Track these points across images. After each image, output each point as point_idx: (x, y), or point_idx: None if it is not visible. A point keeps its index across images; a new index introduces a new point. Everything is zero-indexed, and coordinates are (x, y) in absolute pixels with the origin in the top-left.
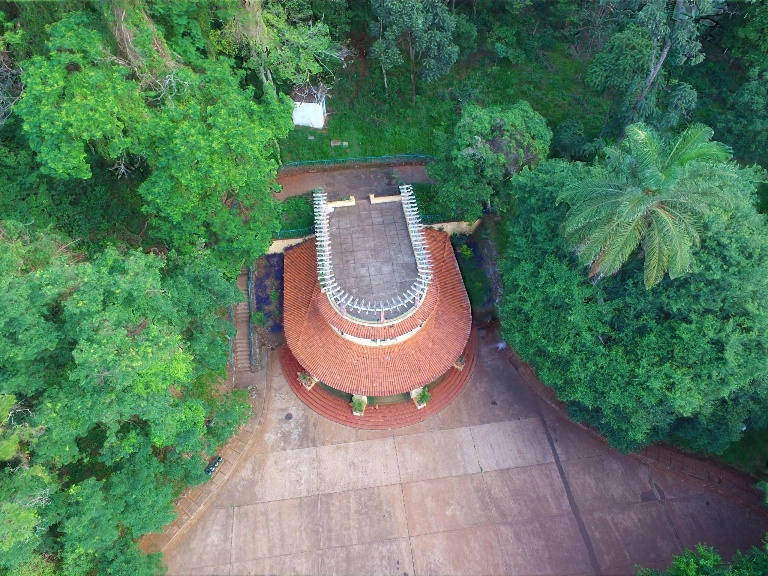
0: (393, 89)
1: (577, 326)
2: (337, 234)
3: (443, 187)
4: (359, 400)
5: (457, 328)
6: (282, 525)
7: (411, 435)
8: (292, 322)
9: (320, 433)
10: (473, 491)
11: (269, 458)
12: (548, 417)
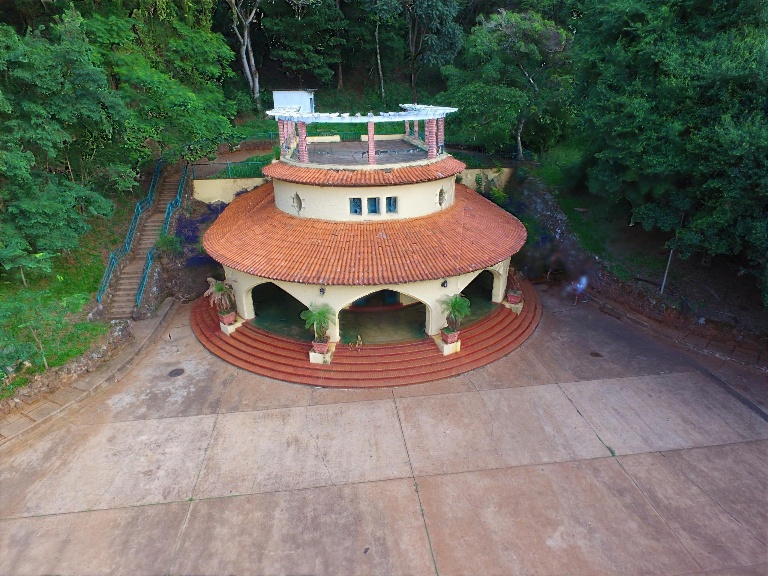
0: (391, 98)
1: (767, 33)
2: (310, 148)
3: (459, 92)
4: (321, 309)
5: (503, 227)
6: (54, 572)
7: (432, 396)
8: (219, 227)
9: (233, 394)
10: (607, 492)
11: (100, 431)
12: (718, 371)
